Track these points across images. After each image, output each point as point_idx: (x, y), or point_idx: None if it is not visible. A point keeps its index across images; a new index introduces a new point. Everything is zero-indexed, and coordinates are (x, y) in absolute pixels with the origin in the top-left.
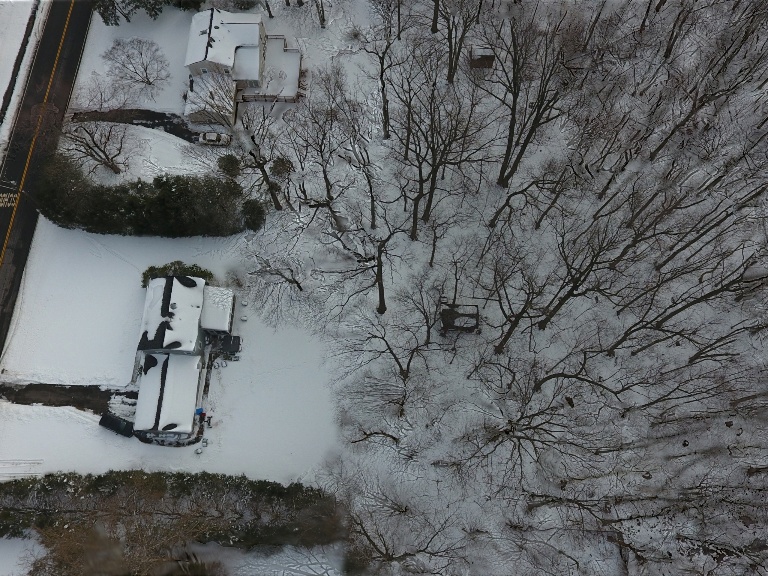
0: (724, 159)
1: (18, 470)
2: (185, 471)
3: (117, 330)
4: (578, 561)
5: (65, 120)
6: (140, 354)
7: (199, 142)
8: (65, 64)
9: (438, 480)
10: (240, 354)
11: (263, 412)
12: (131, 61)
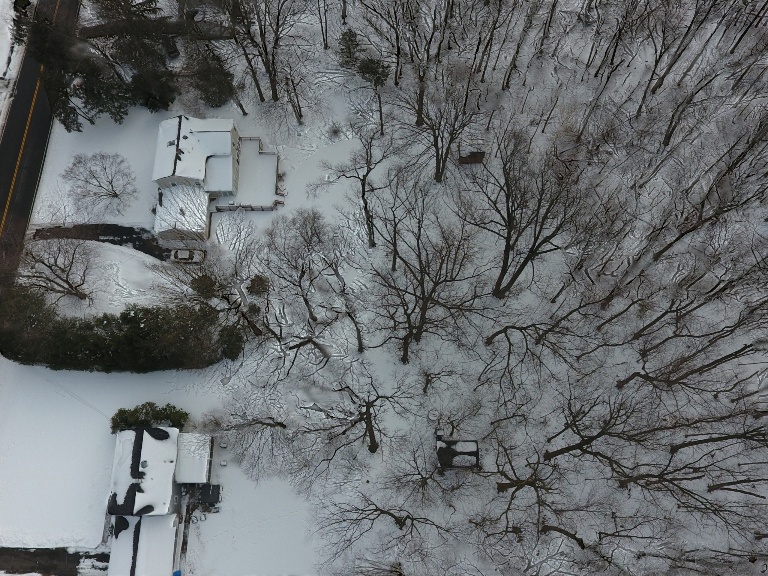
0: (732, 256)
1: None
2: None
3: (85, 482)
4: None
5: (26, 238)
6: None
7: (170, 260)
8: (26, 174)
9: None
10: (220, 505)
11: (247, 572)
12: (94, 176)
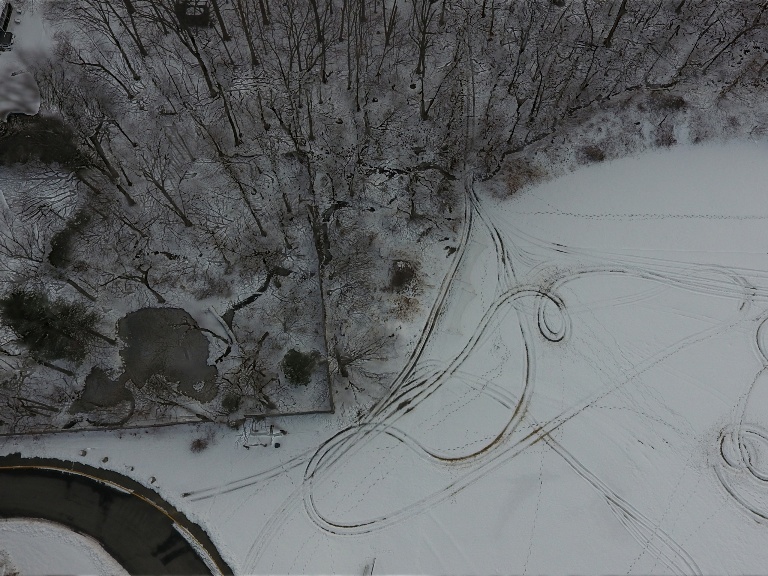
0: None
1: None
2: None
3: None
4: (273, 178)
5: None
6: None
7: None
8: None
9: (157, 116)
10: (12, 46)
11: (26, 83)
12: None
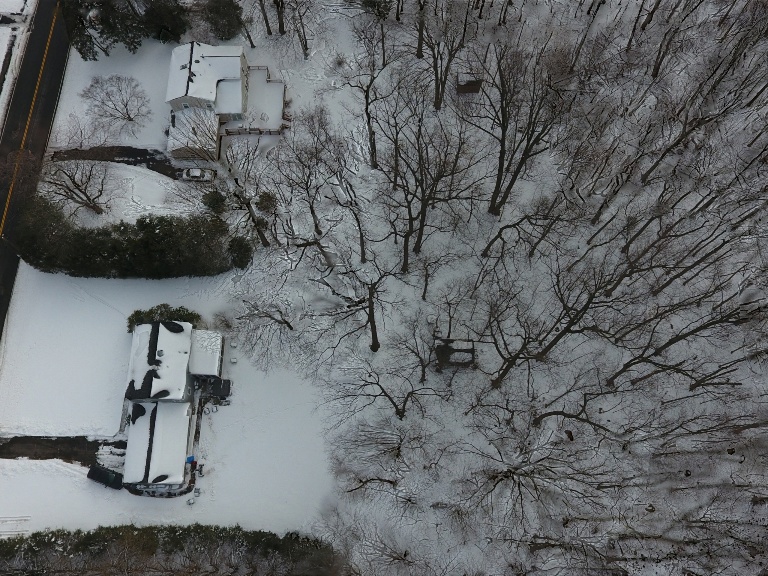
0: (716, 179)
1: (4, 528)
2: (177, 523)
3: (103, 377)
4: None
5: (45, 159)
6: (128, 402)
7: (183, 179)
8: (43, 101)
9: (437, 523)
10: (231, 398)
11: (256, 458)
12: (110, 98)
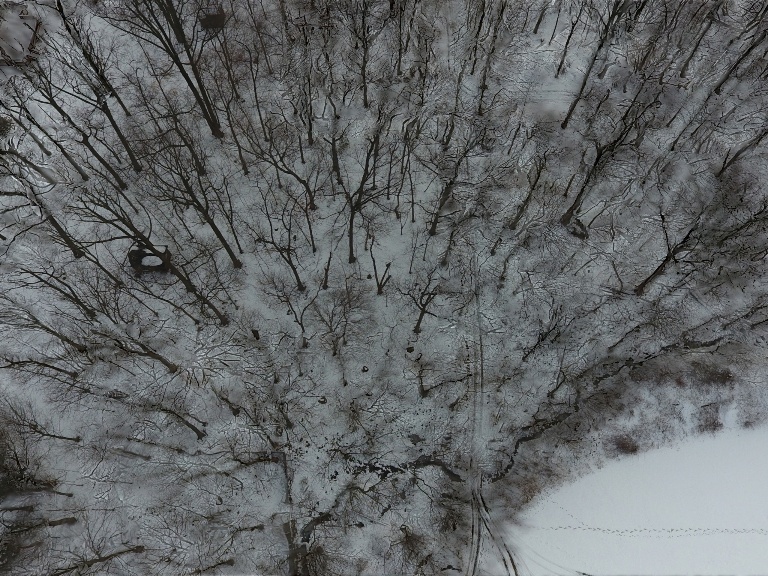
0: (436, 104)
1: None
2: None
3: None
4: (243, 482)
5: None
6: None
7: None
8: None
9: (104, 409)
10: None
11: None
12: None
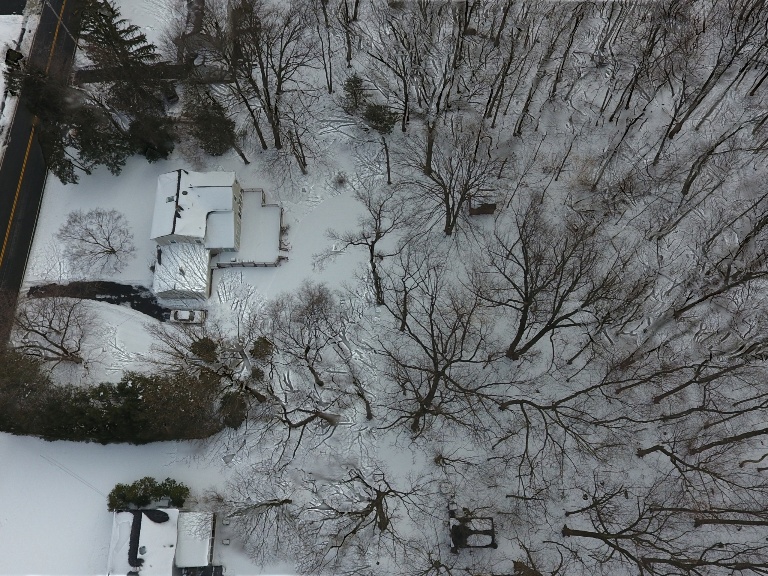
0: (756, 313)
1: None
2: None
3: (81, 563)
4: None
5: (20, 296)
6: None
7: (170, 321)
8: (19, 227)
9: None
10: None
11: None
12: (90, 233)
